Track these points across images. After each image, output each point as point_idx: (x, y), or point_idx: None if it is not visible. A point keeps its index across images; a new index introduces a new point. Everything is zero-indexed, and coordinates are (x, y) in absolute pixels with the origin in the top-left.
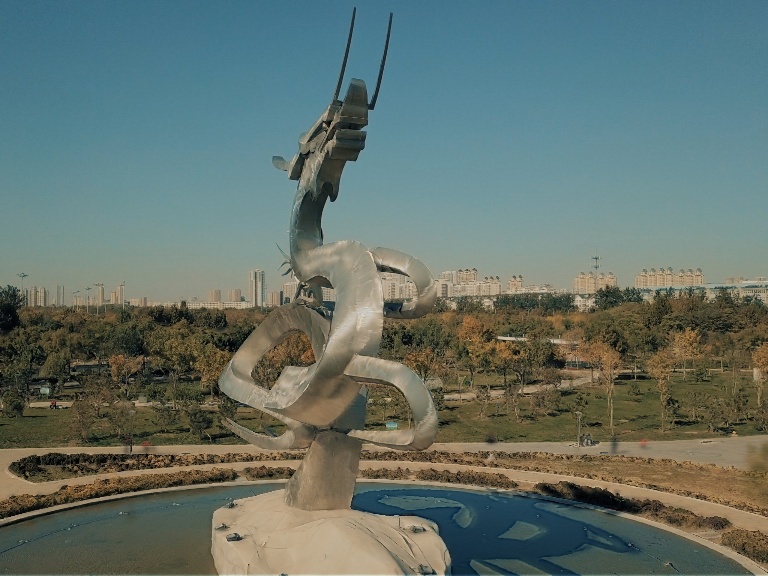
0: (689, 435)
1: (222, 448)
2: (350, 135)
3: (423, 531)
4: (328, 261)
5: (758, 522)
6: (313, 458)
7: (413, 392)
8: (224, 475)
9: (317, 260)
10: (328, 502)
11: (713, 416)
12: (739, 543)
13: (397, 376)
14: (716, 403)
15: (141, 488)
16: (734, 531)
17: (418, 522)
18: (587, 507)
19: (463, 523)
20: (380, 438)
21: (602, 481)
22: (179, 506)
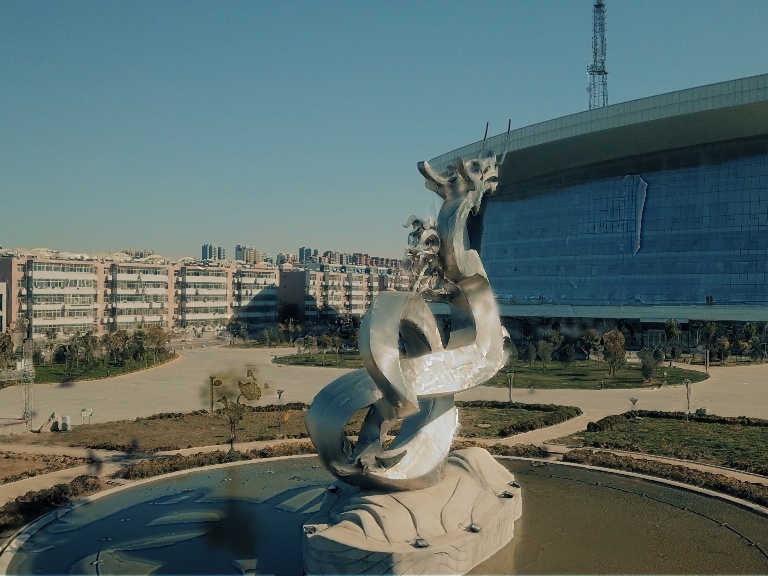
0: None
1: None
2: None
3: None
4: None
5: None
6: None
7: None
8: None
9: None
10: None
11: None
12: None
13: None
14: None
15: None
16: None
17: None
18: (67, 511)
19: (187, 537)
20: None
21: None
22: None
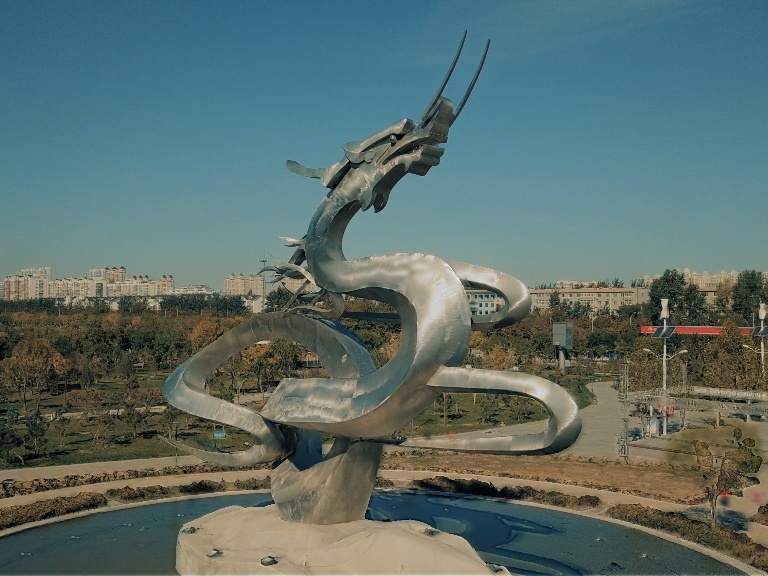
0: (469, 427)
1: (45, 471)
2: (432, 151)
3: (438, 533)
4: (391, 273)
5: (614, 497)
6: (337, 471)
7: (555, 400)
8: (95, 500)
9: (369, 271)
10: (347, 514)
11: (485, 409)
12: (633, 515)
13: (530, 386)
14: (486, 398)
15: (13, 523)
16: (619, 506)
17: (424, 525)
18: (477, 498)
19: None
20: (473, 445)
21: (458, 473)
22: (80, 539)
